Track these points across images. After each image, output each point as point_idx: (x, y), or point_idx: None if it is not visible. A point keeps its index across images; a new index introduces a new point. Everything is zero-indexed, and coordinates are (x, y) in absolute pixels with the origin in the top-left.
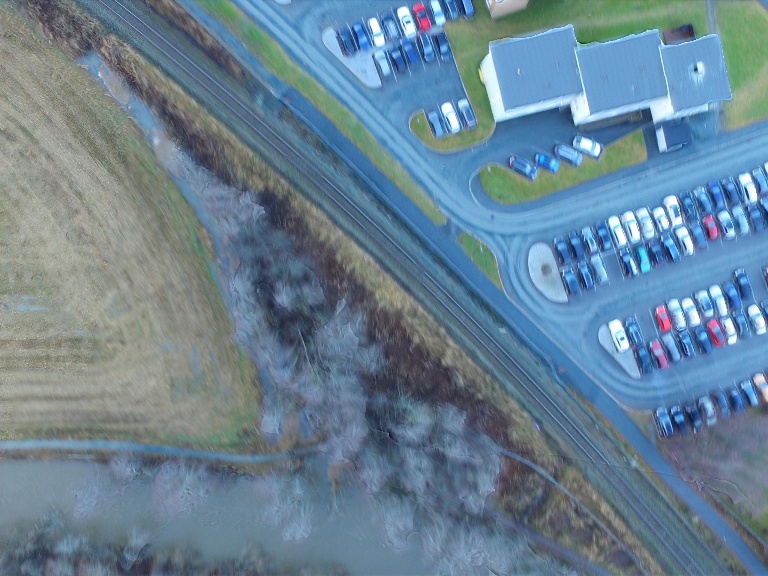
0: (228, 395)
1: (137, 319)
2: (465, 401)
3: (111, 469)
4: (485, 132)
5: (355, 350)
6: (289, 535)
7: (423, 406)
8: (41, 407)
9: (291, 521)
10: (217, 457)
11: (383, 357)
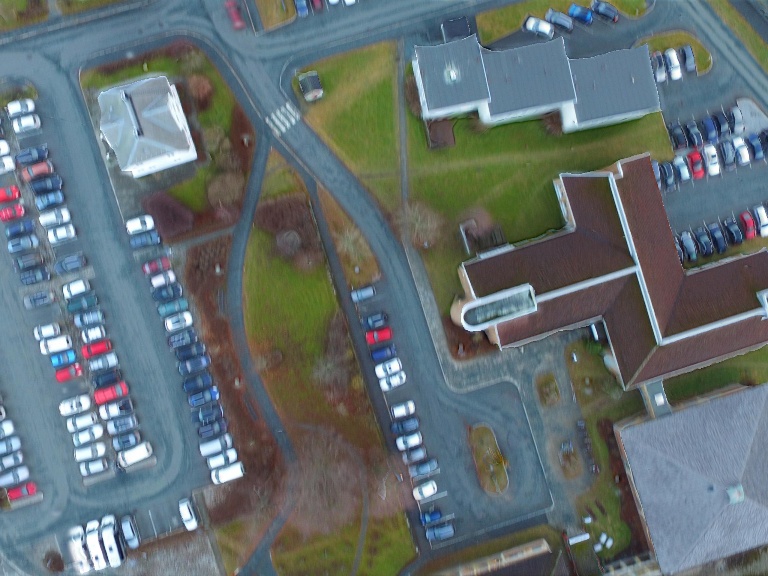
0: None
1: None
2: None
3: None
4: None
5: None
6: None
7: None
8: None
9: None
10: None
11: None
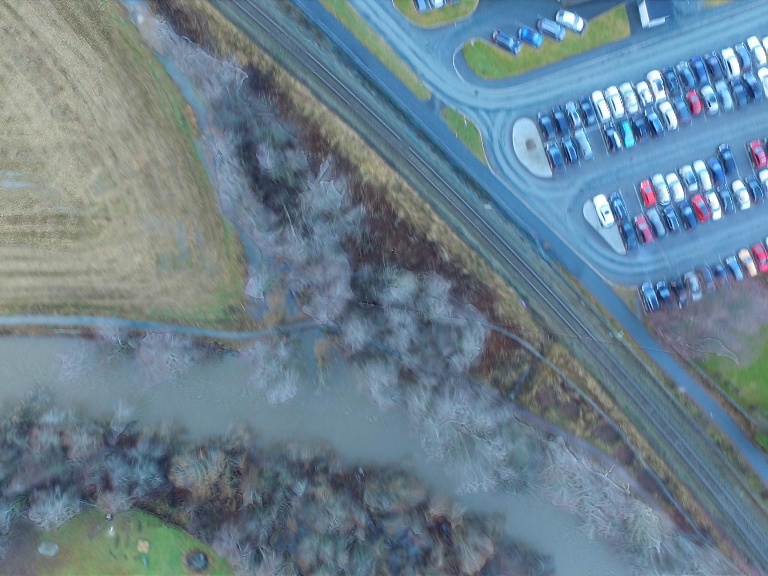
0: (214, 272)
1: (122, 196)
2: (451, 276)
3: (97, 343)
4: (468, 7)
5: (338, 207)
6: (274, 397)
7: (408, 271)
8: (27, 283)
9: (276, 384)
10: (203, 333)
11: (368, 231)
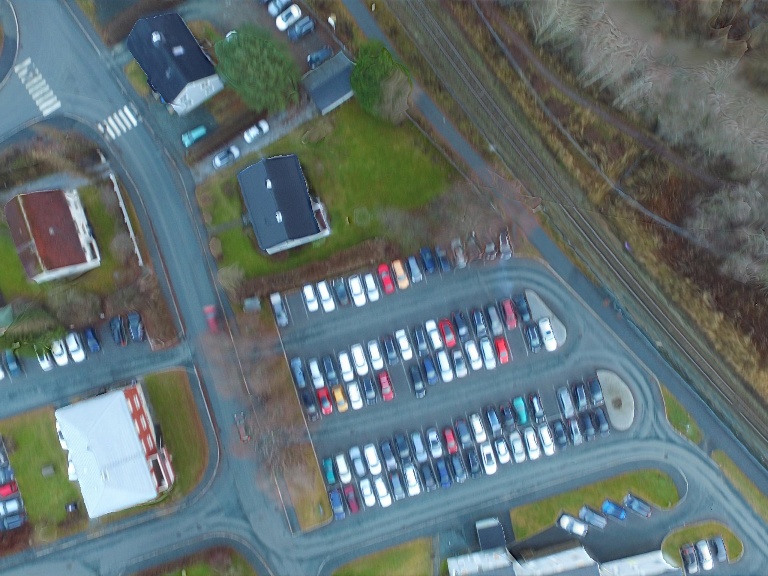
0: None
1: None
2: (704, 277)
3: None
4: (672, 541)
5: None
6: None
7: None
8: None
9: None
10: None
11: None
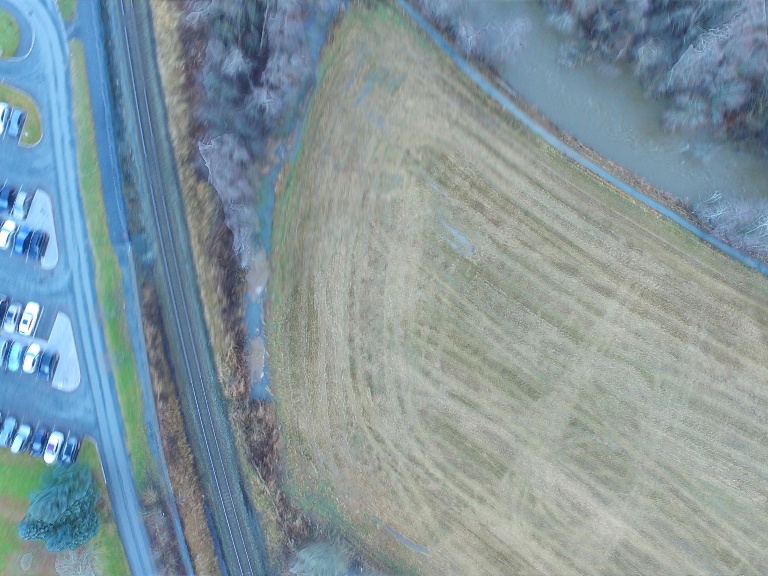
0: (360, 46)
1: (383, 162)
2: None
3: None
4: None
5: None
6: None
7: None
8: (508, 151)
9: None
10: (406, 5)
11: None
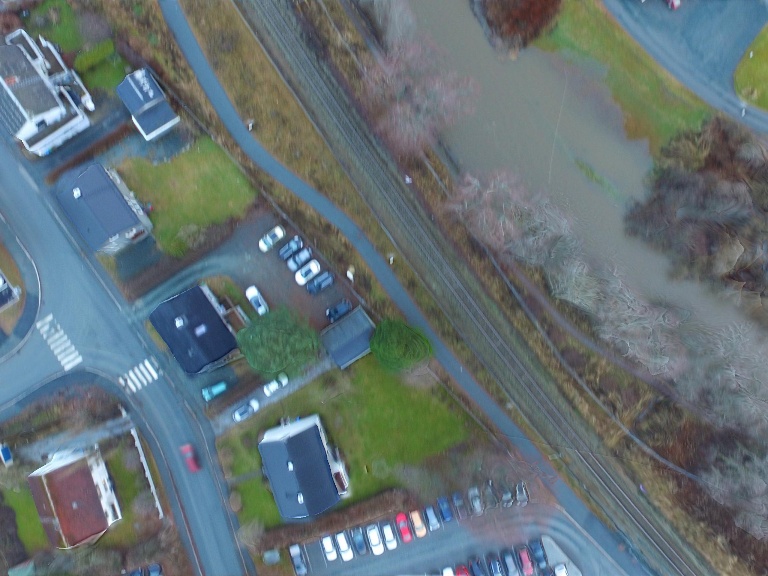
0: None
1: None
2: (718, 521)
3: None
4: None
5: None
6: None
7: None
8: None
9: None
10: None
11: None
